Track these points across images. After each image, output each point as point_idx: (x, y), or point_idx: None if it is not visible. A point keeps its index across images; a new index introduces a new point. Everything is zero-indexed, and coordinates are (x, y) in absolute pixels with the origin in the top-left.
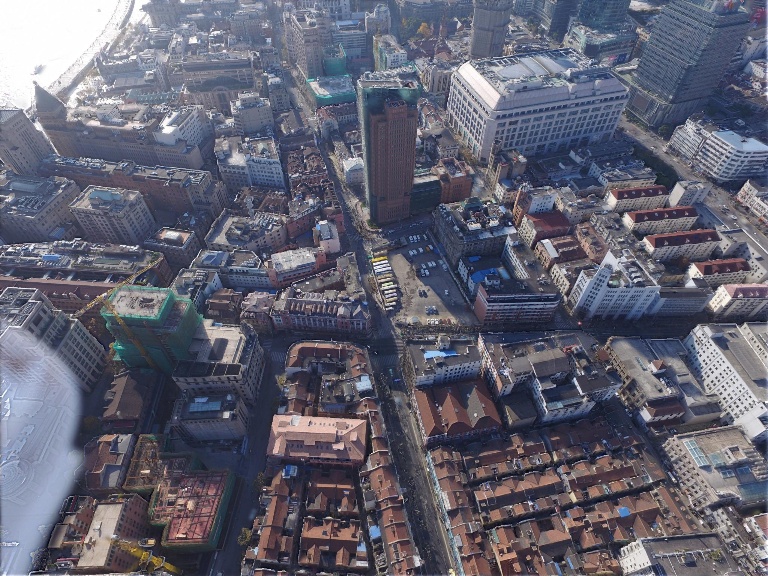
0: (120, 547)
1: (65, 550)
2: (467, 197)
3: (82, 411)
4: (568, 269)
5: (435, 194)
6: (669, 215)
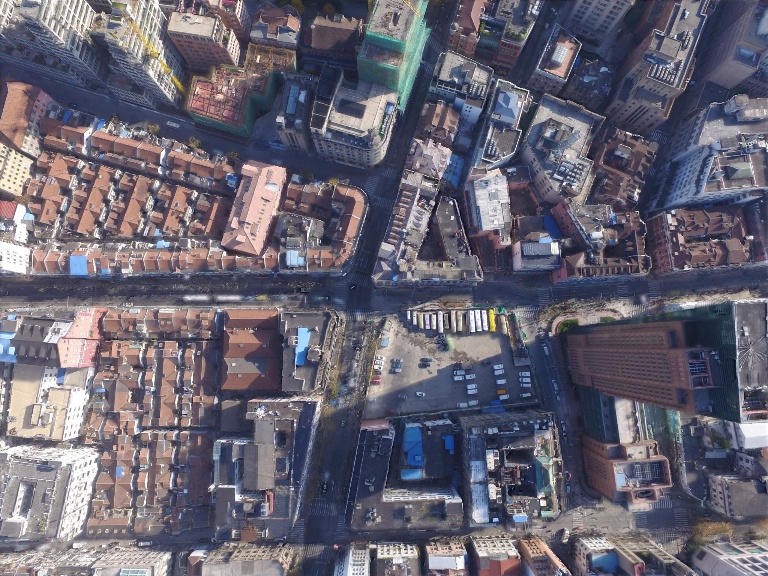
0: (188, 43)
1: (192, 3)
2: (596, 485)
3: (350, 4)
4: (401, 569)
5: (599, 431)
6: None
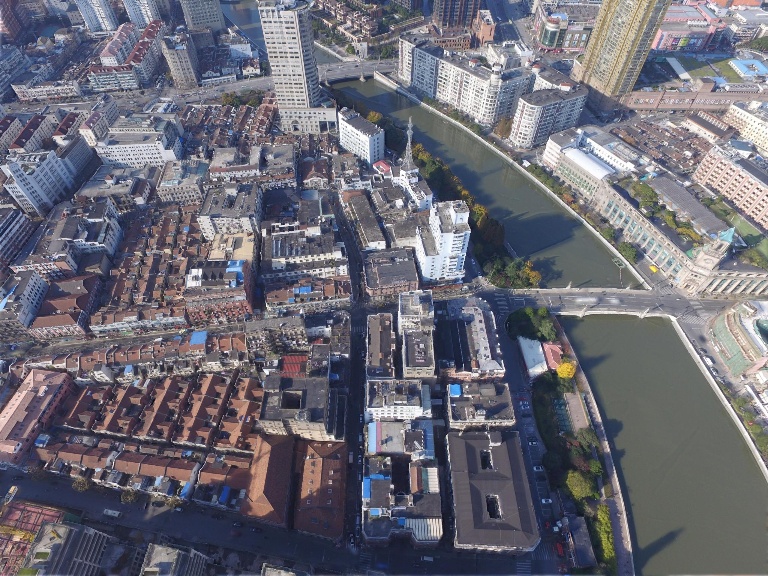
0: None
1: None
2: None
3: None
4: None
5: None
6: (1, 130)
